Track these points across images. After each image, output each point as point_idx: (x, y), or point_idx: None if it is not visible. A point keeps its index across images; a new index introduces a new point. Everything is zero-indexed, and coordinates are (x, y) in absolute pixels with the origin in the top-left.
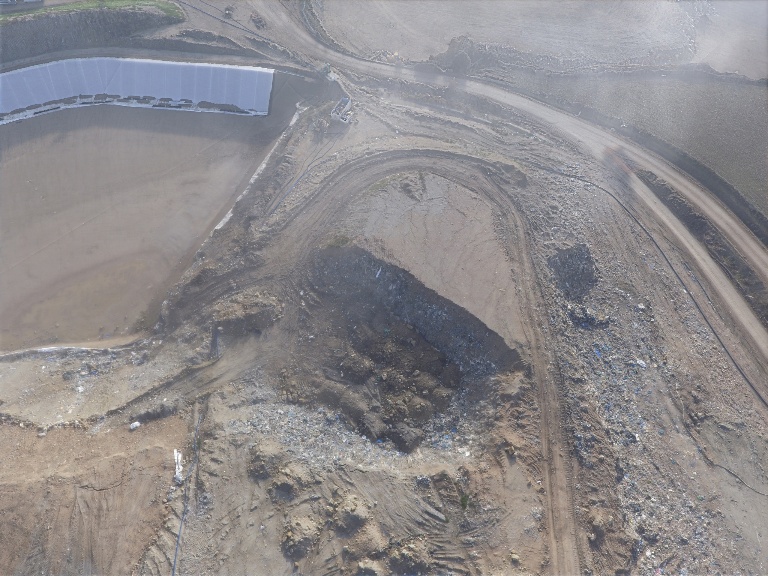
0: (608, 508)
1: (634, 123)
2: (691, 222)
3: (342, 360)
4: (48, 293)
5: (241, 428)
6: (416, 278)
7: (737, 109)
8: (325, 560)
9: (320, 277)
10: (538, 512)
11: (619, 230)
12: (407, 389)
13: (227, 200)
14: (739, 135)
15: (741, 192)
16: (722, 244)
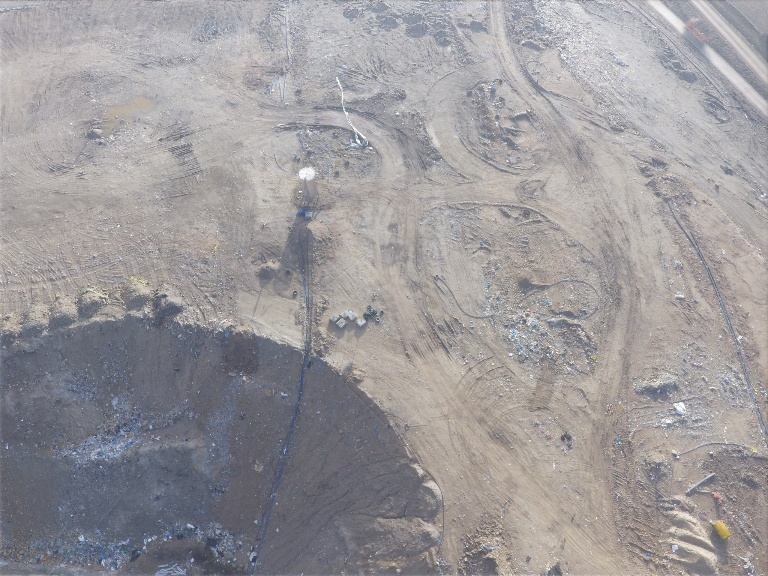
0: (524, 8)
1: None
2: None
3: None
4: None
5: None
6: None
7: None
8: (367, 19)
9: None
10: (484, 3)
11: None
12: None
13: None
14: None
15: None
16: None
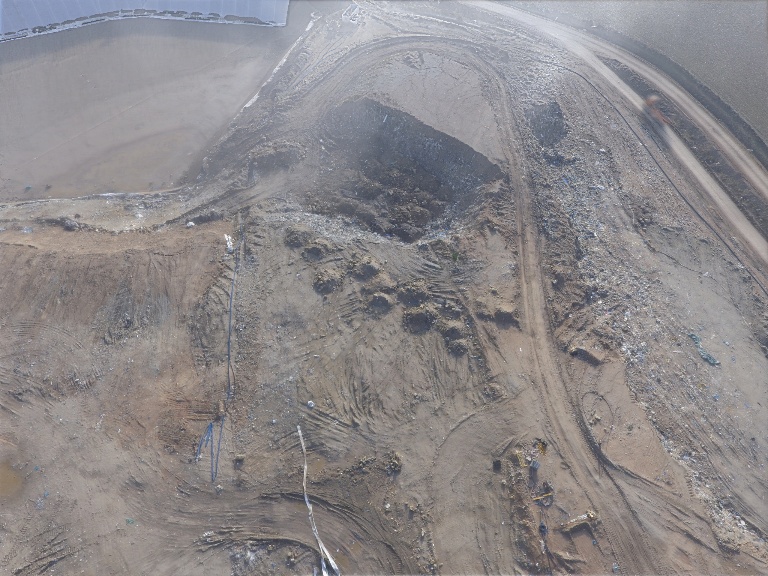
0: (568, 266)
1: (603, 24)
2: (648, 96)
3: (356, 183)
4: (104, 158)
5: (277, 219)
6: (416, 118)
7: (691, 11)
8: (347, 294)
9: (336, 129)
10: (513, 264)
11: (587, 100)
12: (409, 201)
13: (253, 90)
14: (692, 31)
15: (691, 72)
16: (673, 111)
